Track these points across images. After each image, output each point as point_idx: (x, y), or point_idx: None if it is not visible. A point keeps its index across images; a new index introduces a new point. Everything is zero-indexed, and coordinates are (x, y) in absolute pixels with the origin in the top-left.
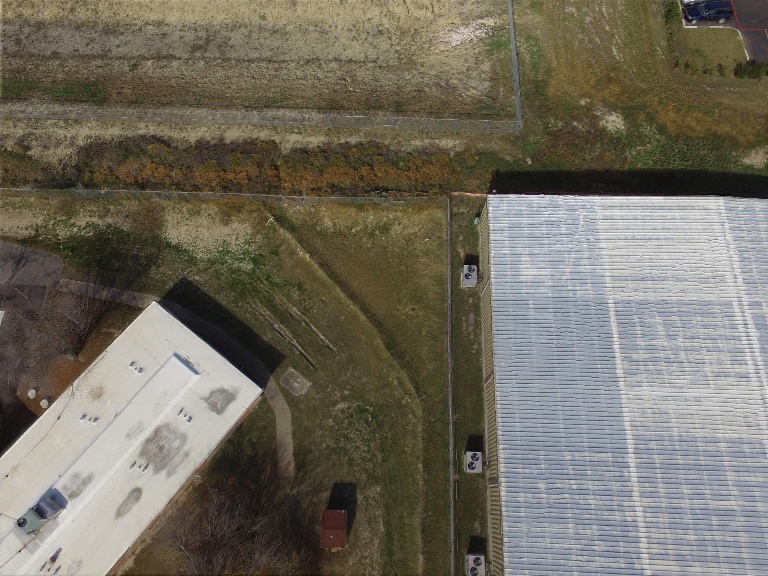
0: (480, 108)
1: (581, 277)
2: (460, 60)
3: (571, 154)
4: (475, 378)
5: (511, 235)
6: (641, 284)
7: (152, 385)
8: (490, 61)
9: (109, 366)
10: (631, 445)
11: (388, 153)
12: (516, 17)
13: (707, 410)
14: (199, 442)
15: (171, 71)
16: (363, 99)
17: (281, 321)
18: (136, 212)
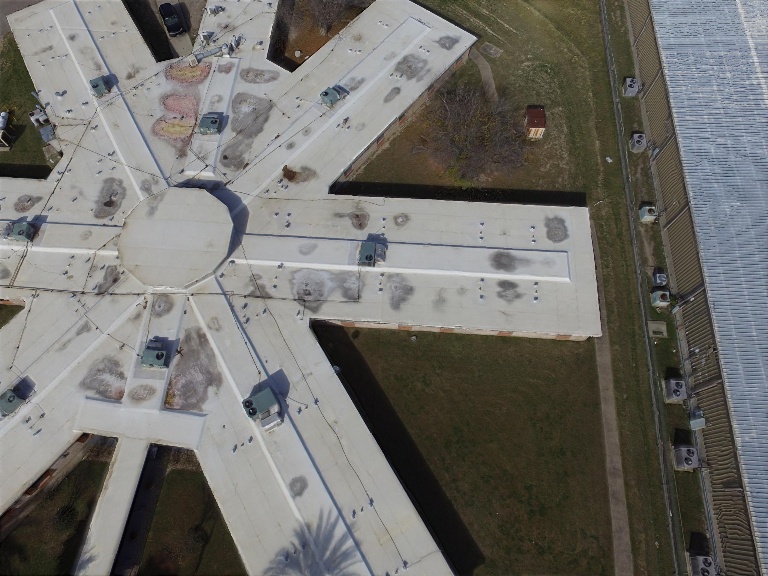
0: None
1: None
2: None
3: None
4: (625, 46)
5: None
6: None
7: (398, 32)
8: None
9: (363, 24)
10: (753, 47)
11: None
12: None
13: None
14: (436, 64)
15: None
16: None
17: (475, 16)
18: None
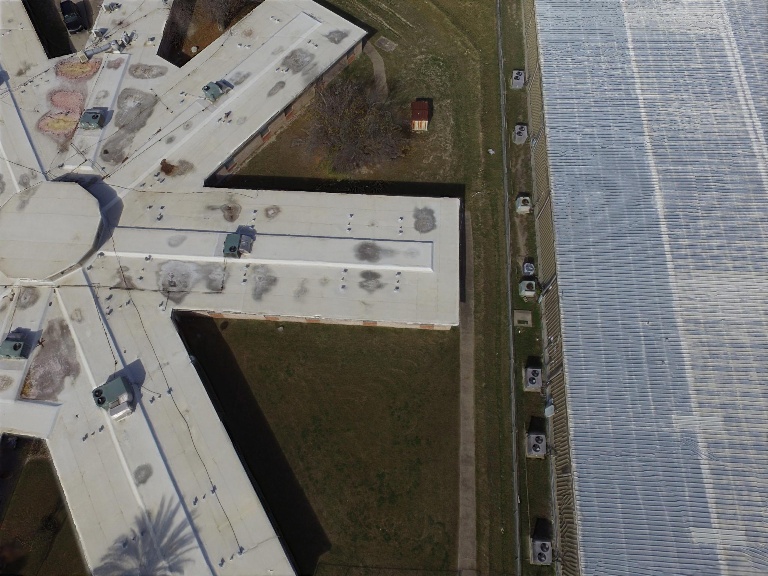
0: None
1: None
2: None
3: None
4: (517, 39)
5: None
6: None
7: (288, 27)
8: None
9: (255, 19)
10: (630, 37)
11: None
12: None
13: (683, 19)
14: (323, 58)
15: None
16: None
17: (374, 11)
18: None
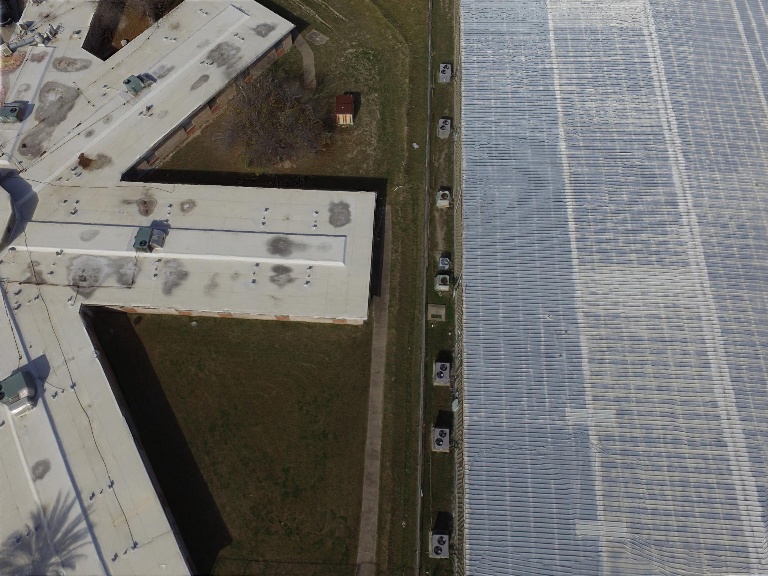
0: None
1: None
2: None
3: None
4: (448, 32)
5: None
6: None
7: (215, 20)
8: None
9: (184, 12)
10: (552, 31)
11: None
12: None
13: (606, 12)
14: (249, 51)
15: None
16: None
17: (307, 4)
18: None
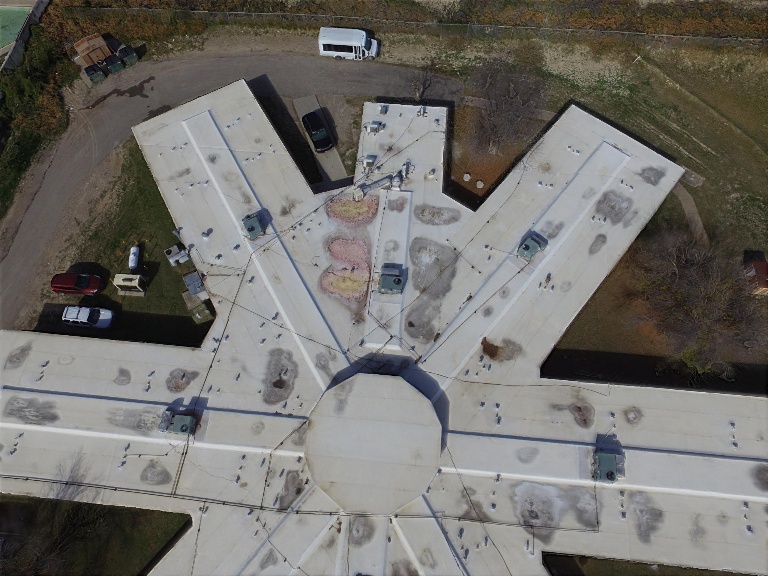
0: None
1: None
2: None
3: None
4: None
5: None
6: None
7: (593, 162)
8: None
9: (549, 149)
10: None
11: (733, 10)
12: None
13: None
14: (644, 204)
15: None
16: None
17: (666, 133)
18: (517, 49)
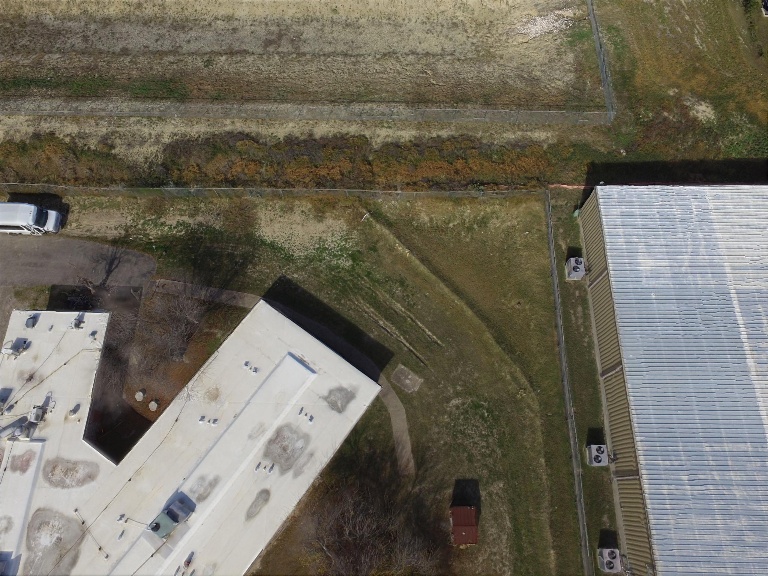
0: (569, 100)
1: (701, 267)
2: (541, 52)
3: (665, 145)
4: (589, 371)
5: (625, 226)
6: (762, 273)
7: (269, 385)
8: (573, 52)
9: (223, 366)
10: None
11: (481, 146)
12: (595, 8)
13: None
14: (323, 441)
15: (247, 66)
16: (449, 92)
17: (386, 318)
18: (227, 210)
